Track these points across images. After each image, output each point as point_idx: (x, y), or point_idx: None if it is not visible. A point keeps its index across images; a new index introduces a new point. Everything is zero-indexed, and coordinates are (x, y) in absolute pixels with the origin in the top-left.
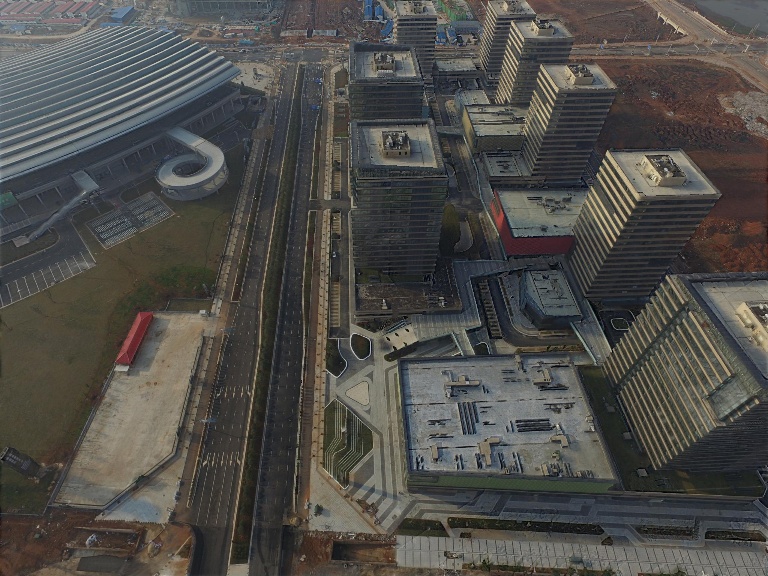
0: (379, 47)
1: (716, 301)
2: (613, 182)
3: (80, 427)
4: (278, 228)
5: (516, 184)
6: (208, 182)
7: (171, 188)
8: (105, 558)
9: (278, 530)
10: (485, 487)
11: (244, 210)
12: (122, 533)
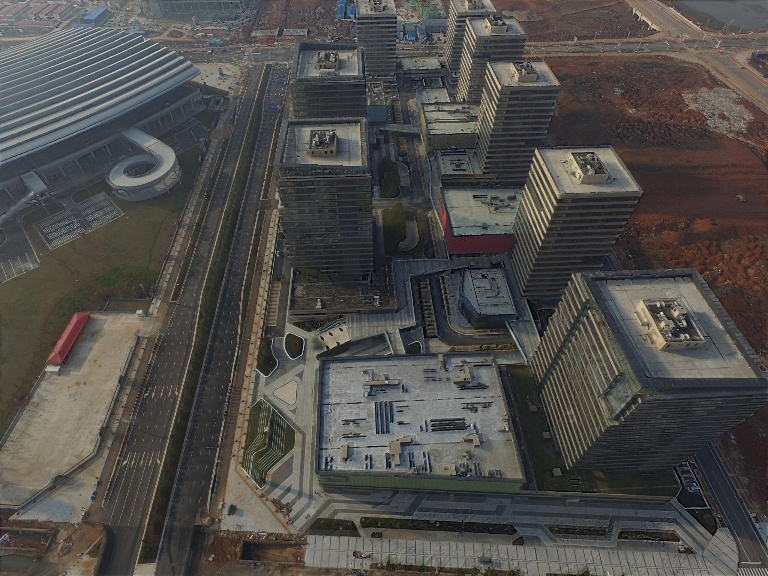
0: (326, 46)
1: (617, 299)
2: (540, 180)
3: (5, 427)
4: (224, 228)
5: (468, 182)
6: (158, 182)
7: (120, 188)
8: (15, 557)
9: (189, 530)
10: (397, 487)
11: (194, 210)
12: (36, 533)
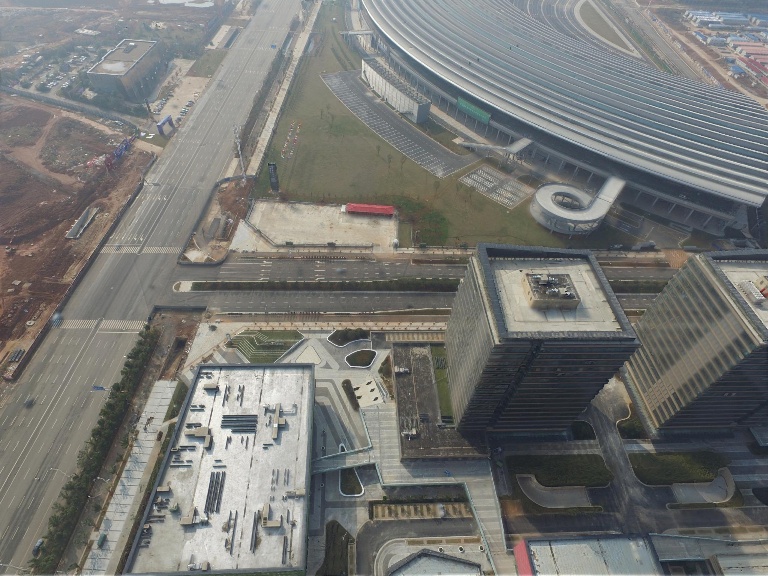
0: None
1: None
2: None
3: (302, 200)
4: None
5: None
6: (552, 217)
7: None
8: (217, 228)
9: None
10: None
11: None
12: None
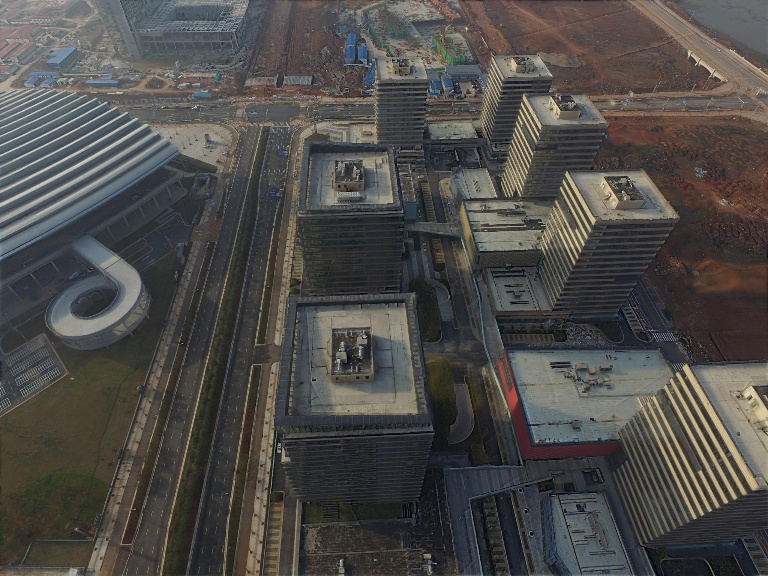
0: (345, 148)
1: None
2: (698, 421)
3: None
4: (204, 402)
5: (531, 319)
6: (115, 327)
7: (63, 337)
8: None
9: None
10: None
11: (164, 364)
12: None
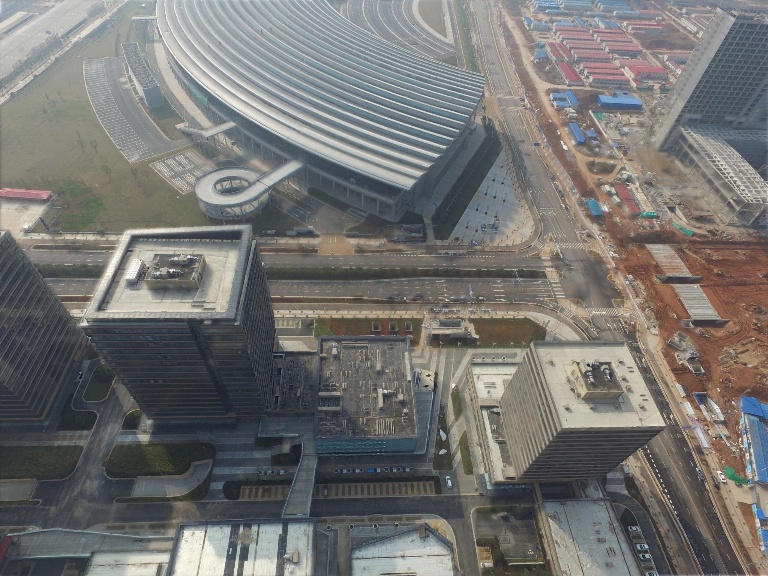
0: None
1: None
2: None
3: None
4: None
5: None
6: None
7: None
8: None
9: None
10: None
11: None
12: None
